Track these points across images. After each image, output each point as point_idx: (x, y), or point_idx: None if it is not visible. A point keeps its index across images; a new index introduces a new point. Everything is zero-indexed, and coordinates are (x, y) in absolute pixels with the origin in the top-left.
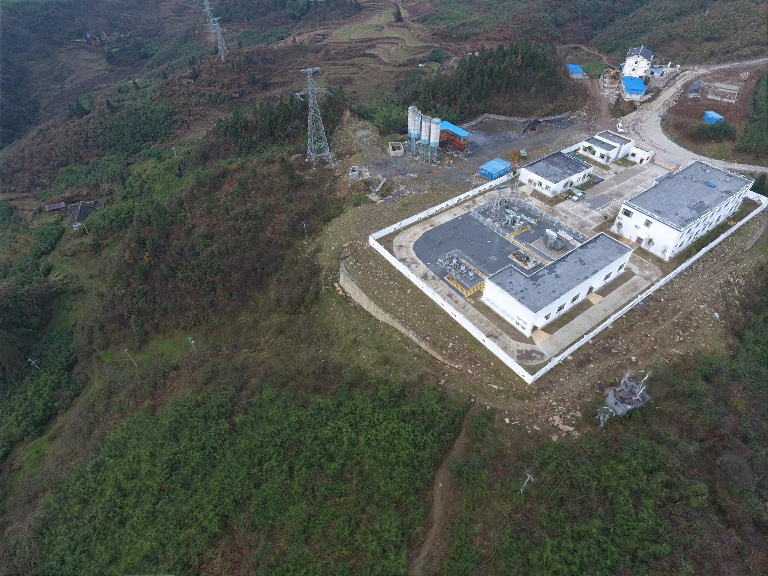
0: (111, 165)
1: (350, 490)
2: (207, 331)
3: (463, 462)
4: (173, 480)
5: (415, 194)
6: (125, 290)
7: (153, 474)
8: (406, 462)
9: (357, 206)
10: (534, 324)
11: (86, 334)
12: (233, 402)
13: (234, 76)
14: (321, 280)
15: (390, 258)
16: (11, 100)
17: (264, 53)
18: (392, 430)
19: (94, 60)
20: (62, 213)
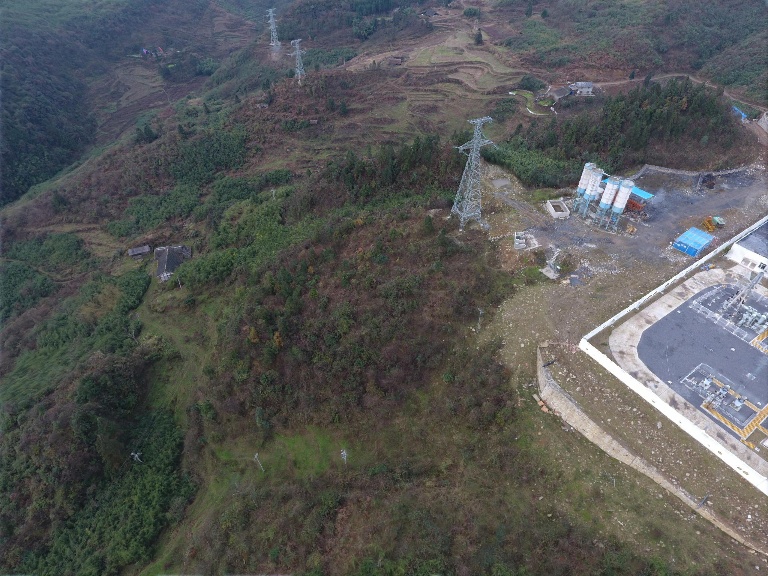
0: (184, 196)
1: None
2: (351, 433)
3: None
4: None
5: (606, 273)
6: (247, 374)
7: None
8: None
9: (531, 284)
10: None
11: (194, 420)
12: None
13: (311, 101)
14: (514, 389)
15: (619, 373)
16: (70, 118)
17: (343, 77)
18: None
19: (150, 76)
20: (145, 258)
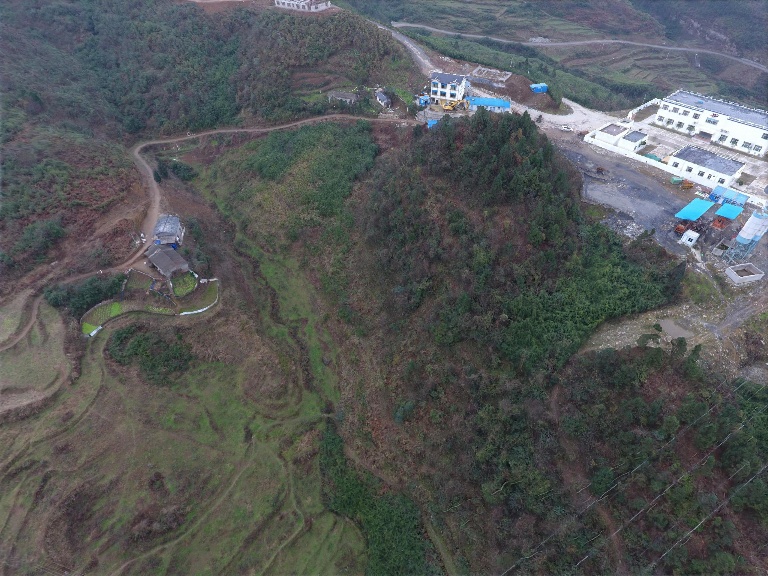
0: None
1: None
2: None
3: None
4: None
5: None
6: None
7: None
8: None
9: None
10: None
11: None
12: None
13: None
14: None
15: None
16: None
17: None
18: None
19: None
20: None
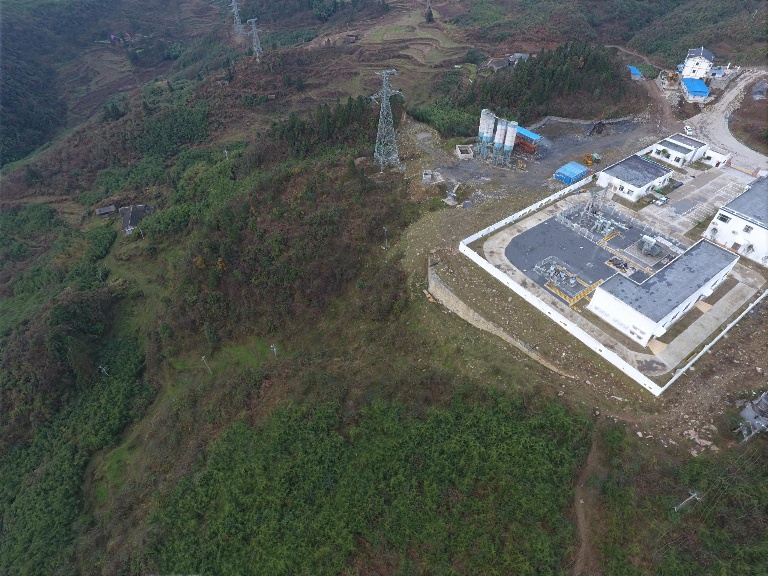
0: (150, 167)
1: (488, 507)
2: (284, 338)
3: (605, 478)
4: (295, 495)
5: (494, 198)
6: (197, 296)
7: (271, 489)
8: (545, 478)
9: (434, 211)
10: (654, 334)
11: (154, 340)
12: (339, 413)
13: (269, 78)
14: (409, 287)
15: (485, 265)
16: (40, 102)
17: (299, 54)
18: (525, 444)
19: (118, 61)
20: (112, 217)
